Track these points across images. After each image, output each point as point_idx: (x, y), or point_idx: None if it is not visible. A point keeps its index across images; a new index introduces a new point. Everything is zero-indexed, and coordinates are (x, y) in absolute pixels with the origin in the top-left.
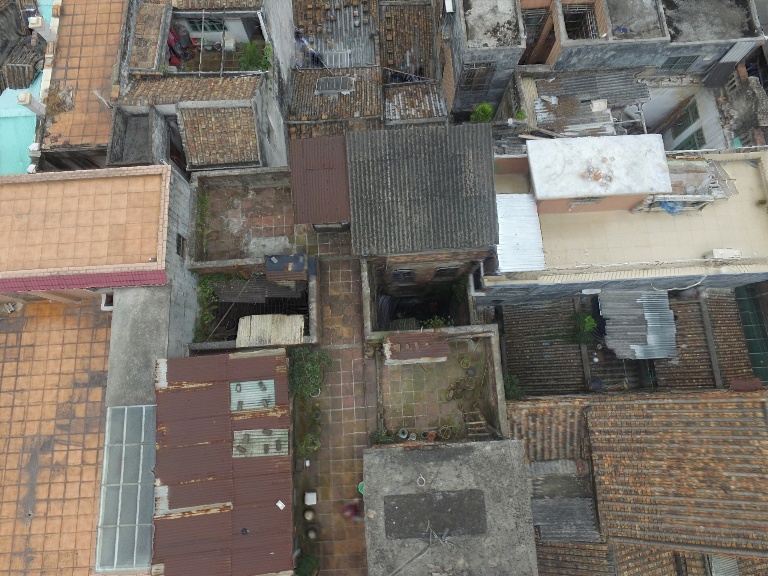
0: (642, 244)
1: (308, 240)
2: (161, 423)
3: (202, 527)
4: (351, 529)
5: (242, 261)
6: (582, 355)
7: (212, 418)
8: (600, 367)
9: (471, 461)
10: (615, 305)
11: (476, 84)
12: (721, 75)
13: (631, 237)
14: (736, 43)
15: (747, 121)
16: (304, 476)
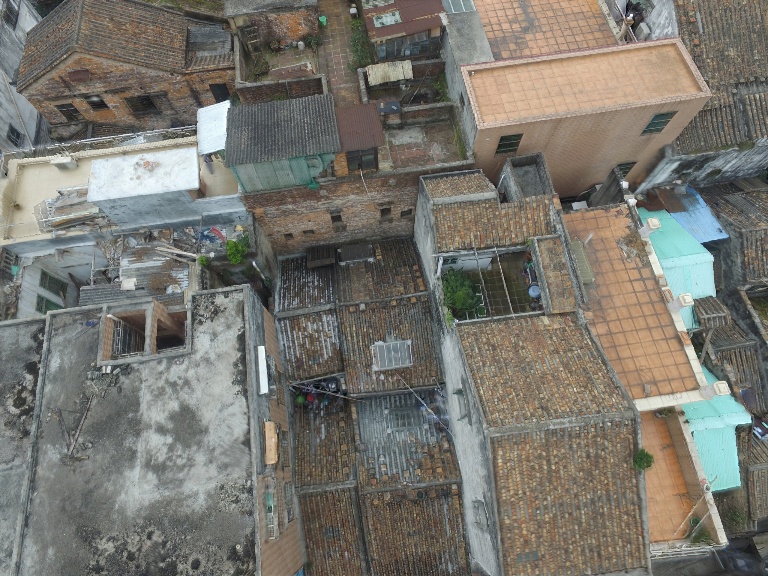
0: None
1: None
2: None
3: None
4: (330, 7)
5: (419, 108)
6: None
7: (409, 6)
8: None
9: (255, 5)
10: None
11: None
12: None
13: None
14: None
15: None
16: None
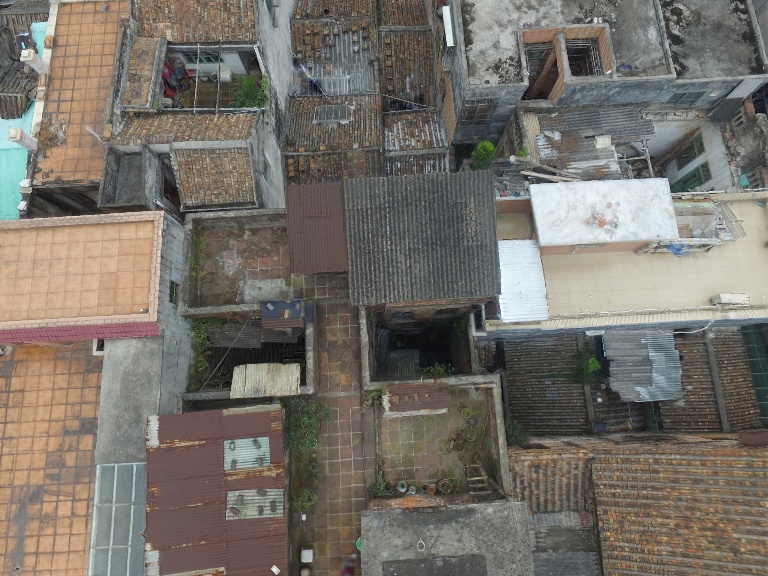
0: (647, 287)
1: (305, 283)
2: (152, 484)
3: None
4: None
5: (237, 307)
6: (585, 395)
7: (205, 478)
8: (604, 407)
9: (472, 524)
10: (619, 346)
11: (477, 119)
12: (727, 110)
13: (636, 279)
14: (743, 80)
15: (754, 159)
16: (300, 531)
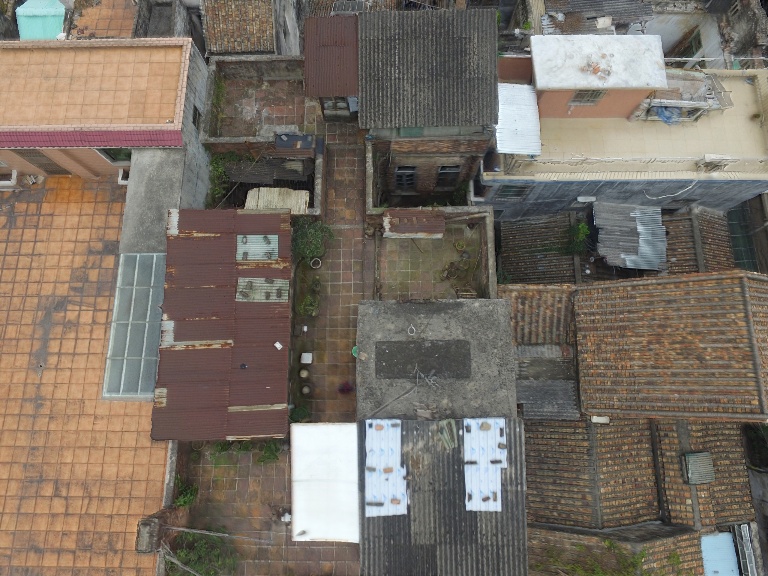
0: (637, 150)
1: (317, 129)
2: (170, 265)
3: (204, 359)
4: (343, 390)
5: (253, 138)
6: (575, 266)
7: (218, 265)
8: (592, 279)
9: (460, 315)
10: (609, 216)
11: None
12: None
13: (627, 143)
14: None
15: (747, 42)
16: (301, 341)
